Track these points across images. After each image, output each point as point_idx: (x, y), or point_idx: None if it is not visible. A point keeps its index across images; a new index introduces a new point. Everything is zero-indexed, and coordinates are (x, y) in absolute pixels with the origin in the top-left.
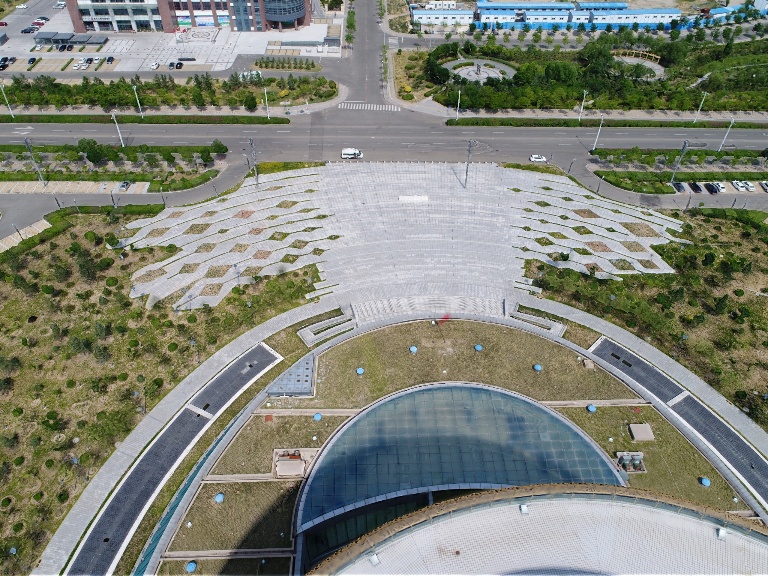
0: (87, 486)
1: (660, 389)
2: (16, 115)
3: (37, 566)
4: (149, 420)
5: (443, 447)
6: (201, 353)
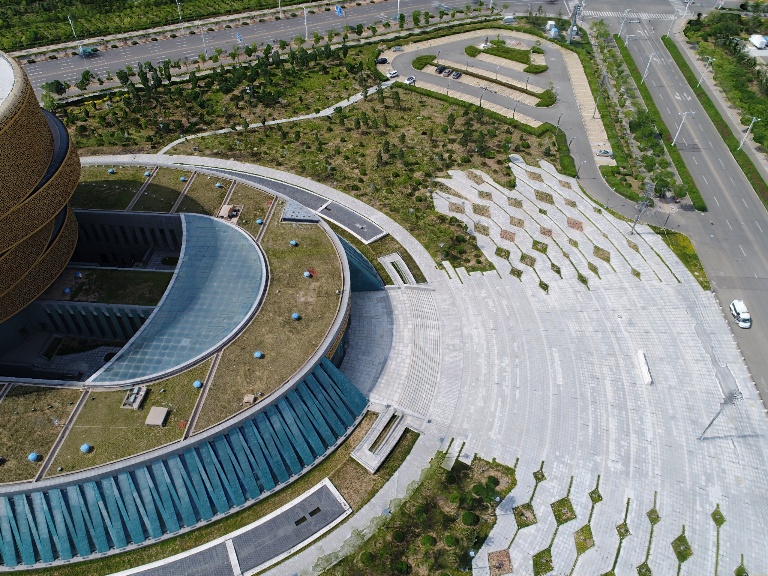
0: (283, 171)
1: (254, 543)
2: (702, 87)
3: (241, 163)
4: (325, 188)
5: (205, 279)
6: (382, 205)
